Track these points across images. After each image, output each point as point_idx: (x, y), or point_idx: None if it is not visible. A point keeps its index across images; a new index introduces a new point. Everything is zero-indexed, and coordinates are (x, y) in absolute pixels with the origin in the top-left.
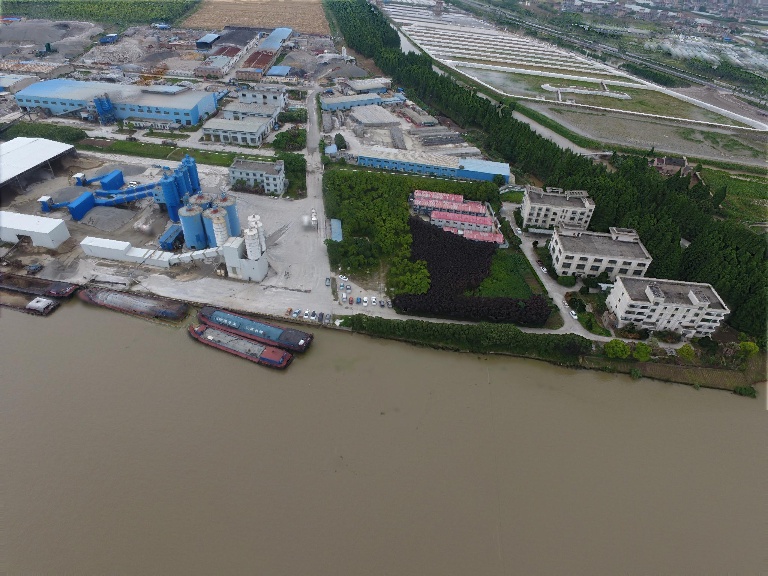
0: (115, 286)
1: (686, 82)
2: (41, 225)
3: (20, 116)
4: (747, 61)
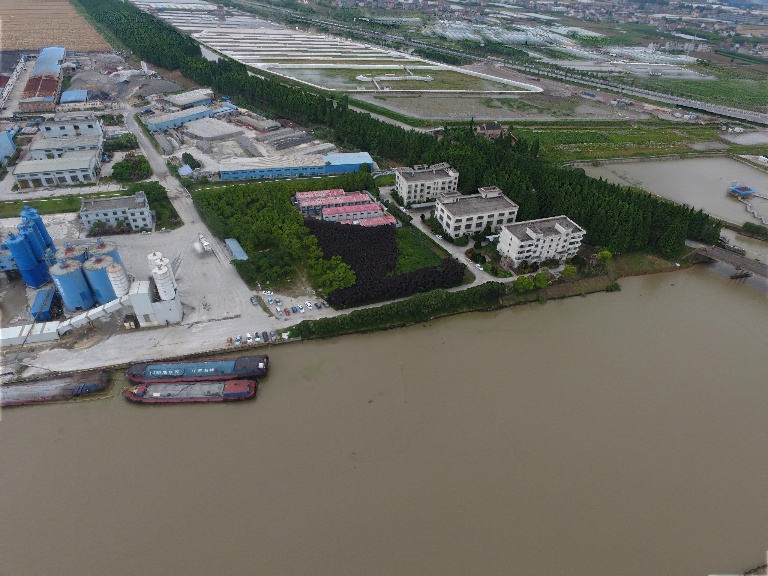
0: None
1: (468, 60)
2: None
3: None
4: (501, 38)
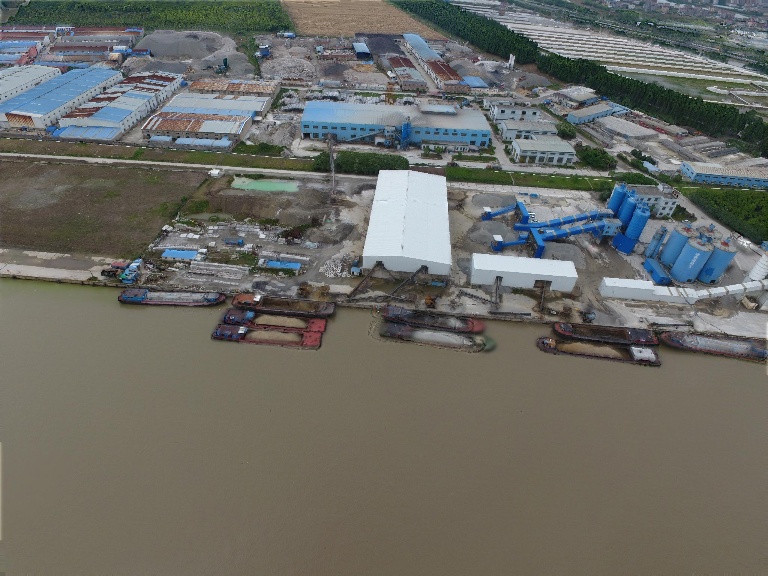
0: (680, 328)
1: None
2: (560, 269)
3: (330, 145)
4: None
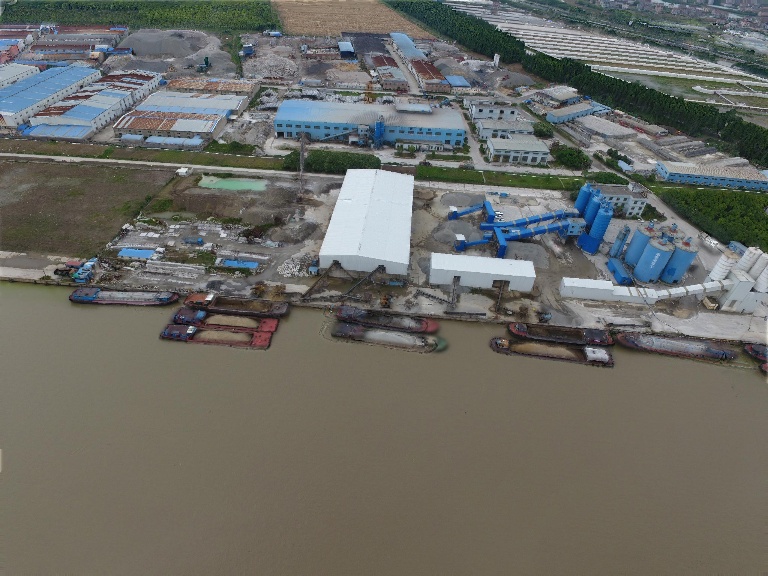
0: (637, 329)
1: None
2: (518, 268)
3: (301, 143)
4: None
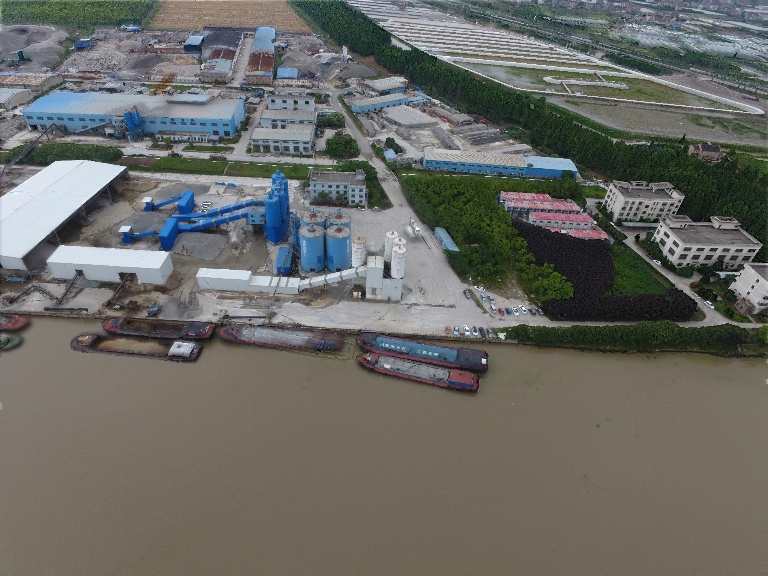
0: (253, 320)
1: (668, 70)
2: (146, 260)
3: (39, 136)
4: (702, 48)
